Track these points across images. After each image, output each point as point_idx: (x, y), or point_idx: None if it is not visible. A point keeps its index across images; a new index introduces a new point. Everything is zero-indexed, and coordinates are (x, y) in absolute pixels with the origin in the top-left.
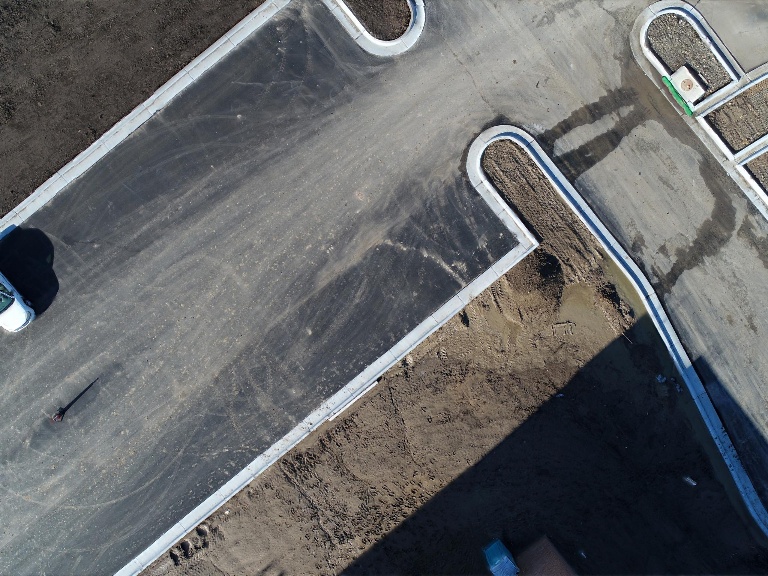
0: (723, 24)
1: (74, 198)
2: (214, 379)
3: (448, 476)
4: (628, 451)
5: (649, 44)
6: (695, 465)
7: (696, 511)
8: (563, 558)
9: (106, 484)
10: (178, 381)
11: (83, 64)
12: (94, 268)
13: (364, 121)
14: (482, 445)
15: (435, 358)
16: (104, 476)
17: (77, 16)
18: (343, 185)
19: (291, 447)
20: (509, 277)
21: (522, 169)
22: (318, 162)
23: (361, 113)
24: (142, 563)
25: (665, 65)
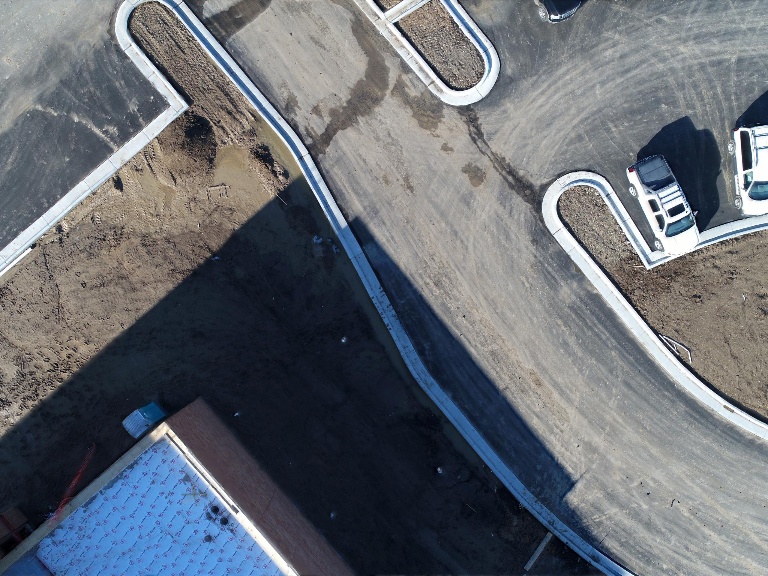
0: None
1: None
2: None
3: (102, 340)
4: (285, 312)
5: None
6: (352, 325)
7: (355, 371)
8: (217, 418)
9: None
10: None
11: None
12: None
13: None
14: (136, 309)
15: (89, 223)
16: None
17: None
18: None
19: None
20: (160, 140)
21: (171, 31)
22: None
23: None
24: None
25: None
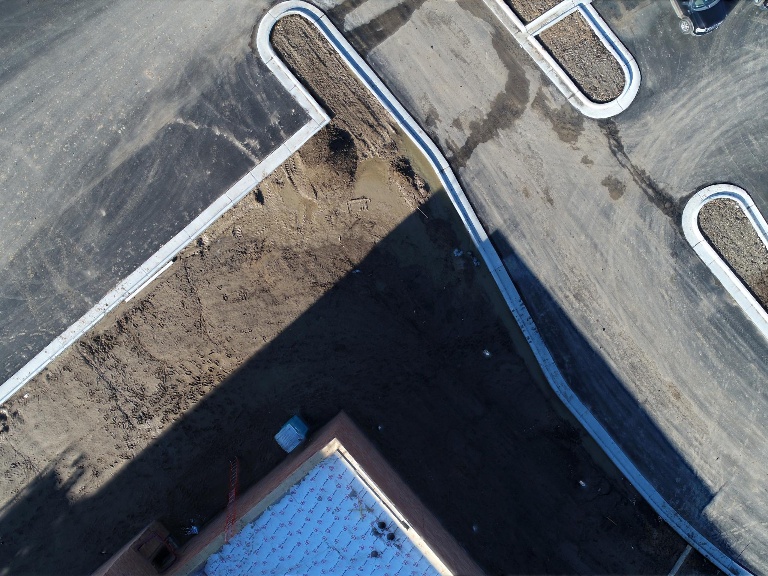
0: None
1: None
2: (9, 263)
3: (244, 353)
4: (426, 325)
5: None
6: (493, 338)
7: (495, 384)
8: (360, 432)
9: None
10: None
11: None
12: None
13: None
14: (278, 322)
15: (230, 237)
16: None
17: None
18: (133, 64)
19: (87, 328)
20: (302, 153)
21: (312, 44)
22: (106, 41)
23: None
24: None
25: None
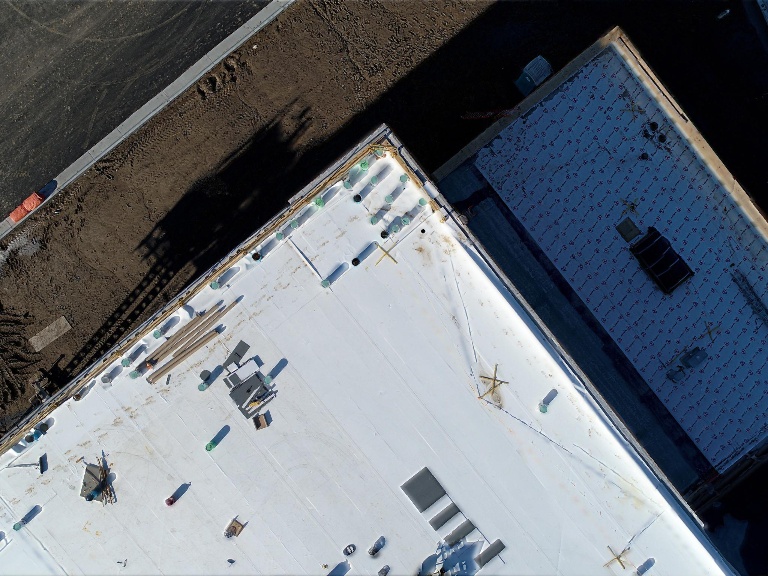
0: None
1: None
2: None
3: (479, 8)
4: None
5: None
6: (728, 4)
7: (728, 51)
8: None
9: (132, 16)
10: None
11: None
12: None
13: None
14: None
15: None
16: (130, 8)
17: None
18: None
19: None
20: None
21: None
22: None
23: None
24: (169, 96)
25: None
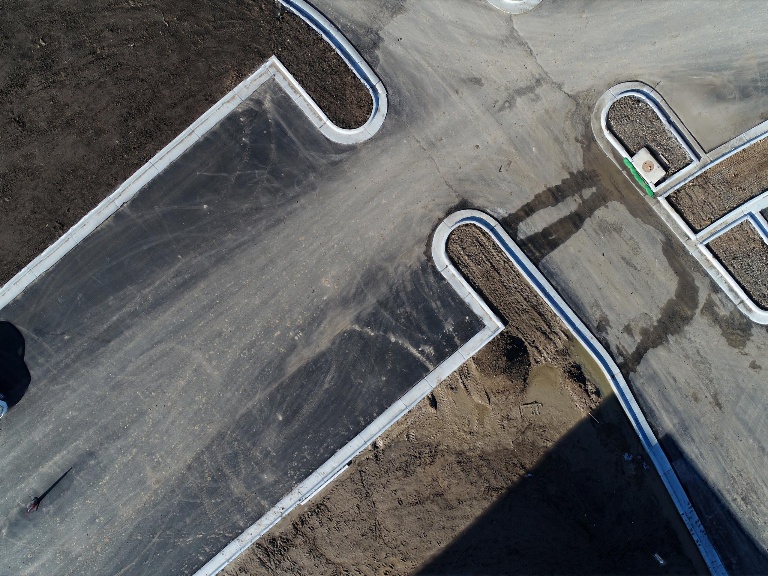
0: (683, 105)
1: (44, 291)
2: (186, 466)
3: (419, 557)
4: (596, 529)
5: (610, 126)
6: (662, 541)
7: None
8: None
9: (82, 571)
10: (151, 468)
11: (49, 159)
12: (65, 359)
13: (329, 209)
14: (452, 526)
15: (404, 441)
16: (80, 563)
17: (42, 112)
18: (310, 272)
19: (264, 532)
20: (476, 360)
21: (487, 253)
22: (285, 250)
23: (326, 201)
24: None
25: (626, 147)
